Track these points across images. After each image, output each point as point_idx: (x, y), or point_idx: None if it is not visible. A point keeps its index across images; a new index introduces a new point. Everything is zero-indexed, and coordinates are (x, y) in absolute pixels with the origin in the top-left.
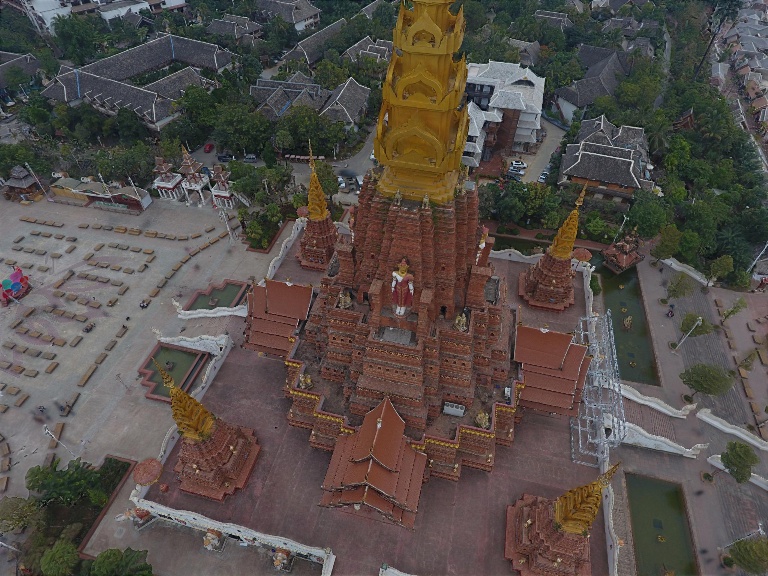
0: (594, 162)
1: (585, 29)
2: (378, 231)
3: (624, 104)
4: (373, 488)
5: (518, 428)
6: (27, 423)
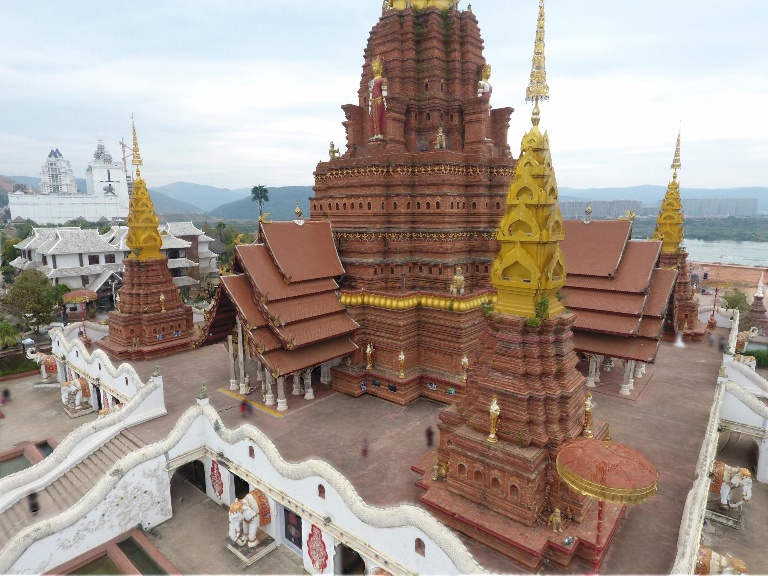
0: None
1: None
2: (443, 49)
3: None
4: None
5: None
6: None
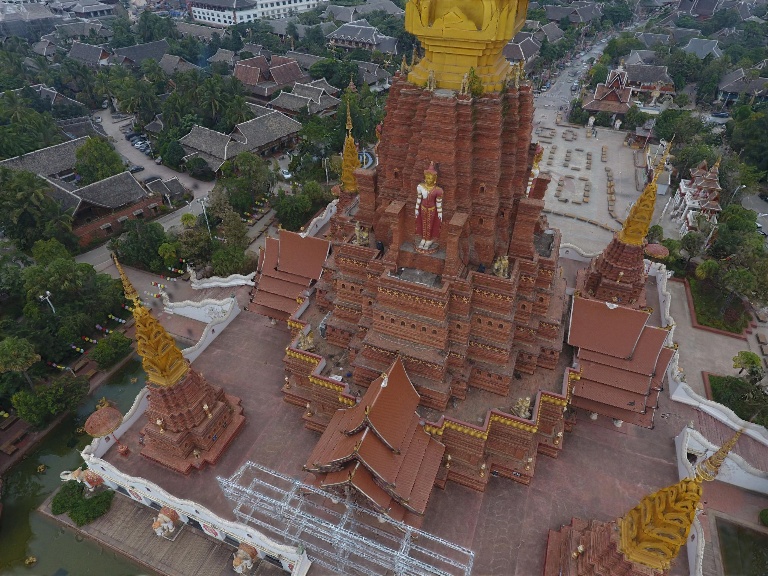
0: None
1: None
2: None
3: None
4: None
5: None
6: None
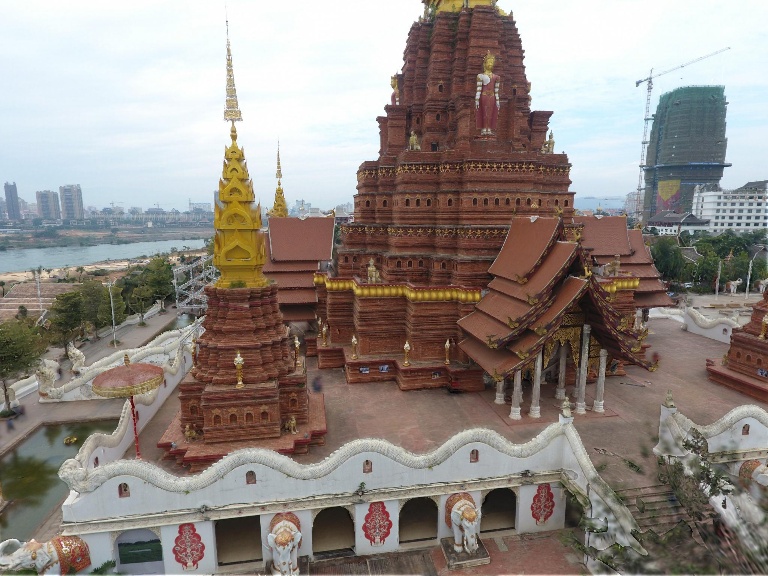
0: None
1: None
2: None
3: None
4: None
5: None
6: None
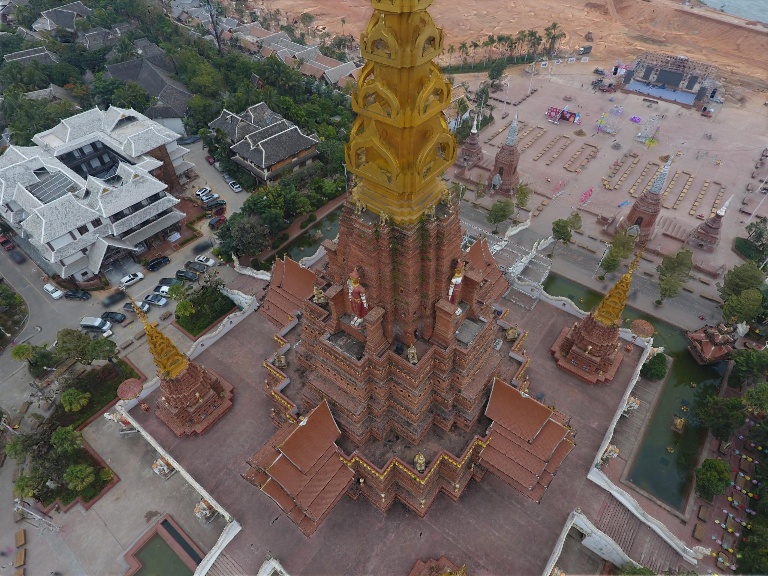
0: (274, 145)
1: (78, 53)
2: (418, 261)
3: (210, 96)
4: None
5: None
6: None
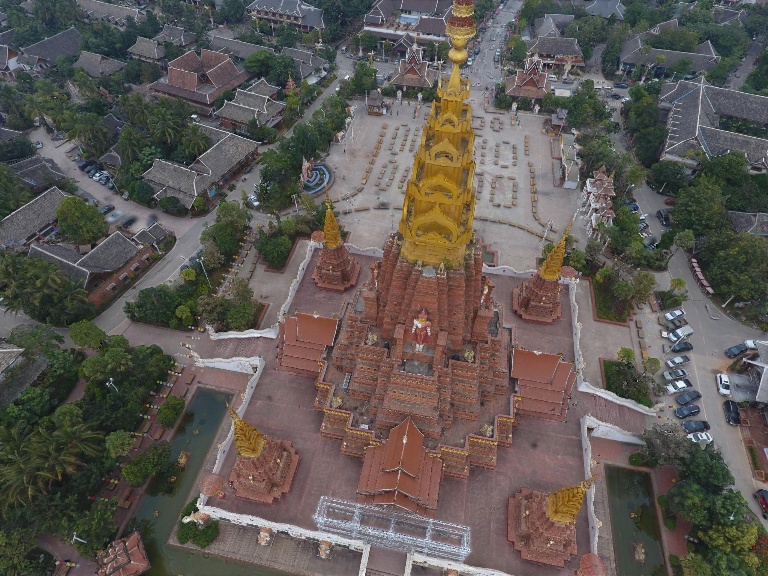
0: None
1: None
2: None
3: None
4: (285, 325)
5: (359, 464)
6: (370, 196)
